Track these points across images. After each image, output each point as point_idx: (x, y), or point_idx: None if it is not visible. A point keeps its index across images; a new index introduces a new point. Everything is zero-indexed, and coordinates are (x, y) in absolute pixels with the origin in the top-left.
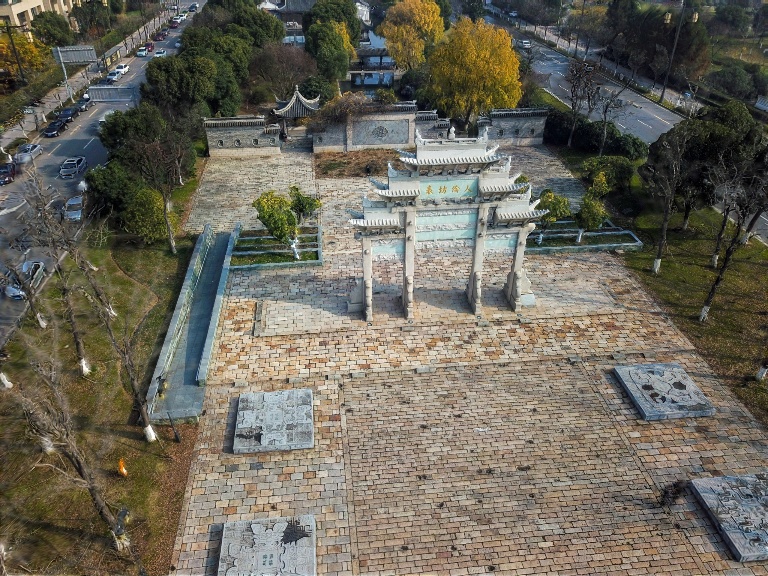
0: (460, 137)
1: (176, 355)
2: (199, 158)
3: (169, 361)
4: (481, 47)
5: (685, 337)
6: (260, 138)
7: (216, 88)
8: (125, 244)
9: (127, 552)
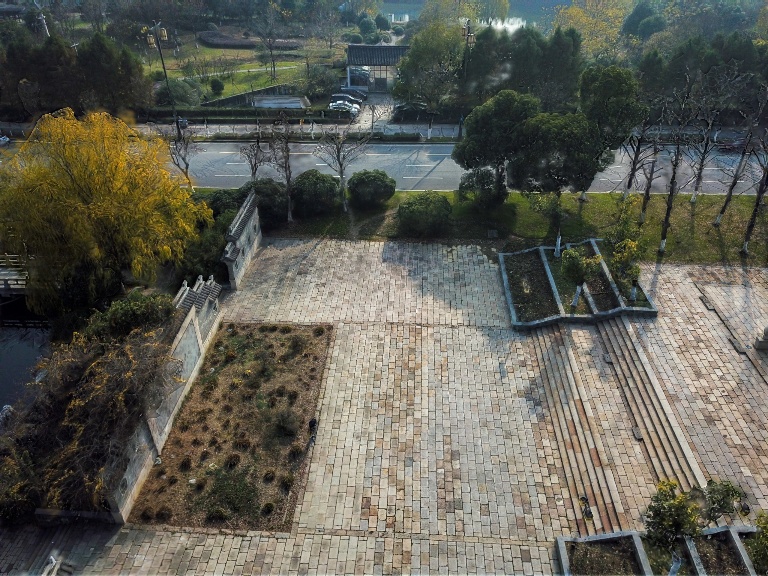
0: None
1: None
2: None
3: None
4: None
5: None
6: None
7: None
8: None
9: None
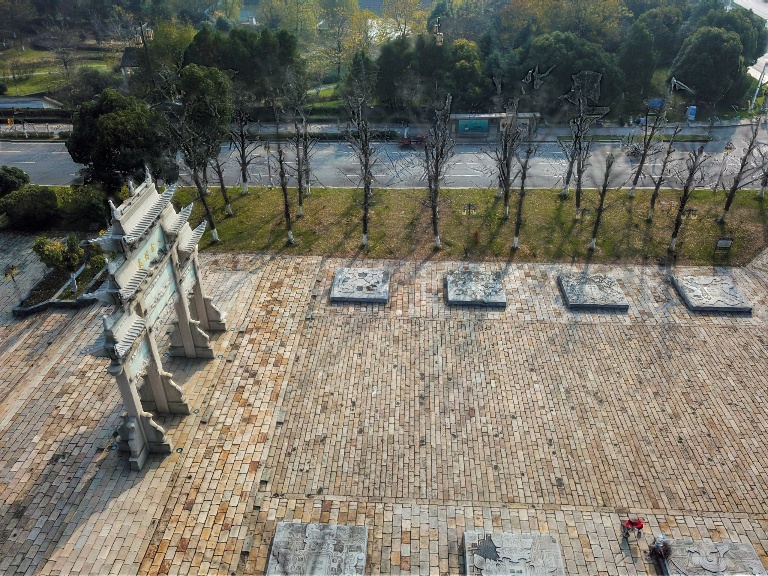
0: None
1: None
2: None
3: None
4: None
5: (308, 256)
6: None
7: None
8: None
9: None
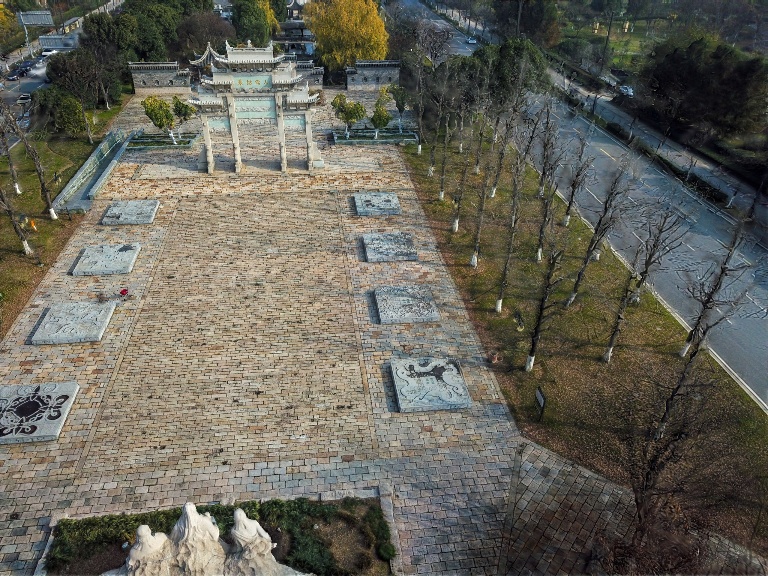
0: (341, 86)
1: (80, 189)
2: (127, 95)
3: (73, 189)
4: (352, 13)
5: (412, 183)
6: (174, 79)
7: (143, 42)
8: (57, 139)
9: (31, 256)
